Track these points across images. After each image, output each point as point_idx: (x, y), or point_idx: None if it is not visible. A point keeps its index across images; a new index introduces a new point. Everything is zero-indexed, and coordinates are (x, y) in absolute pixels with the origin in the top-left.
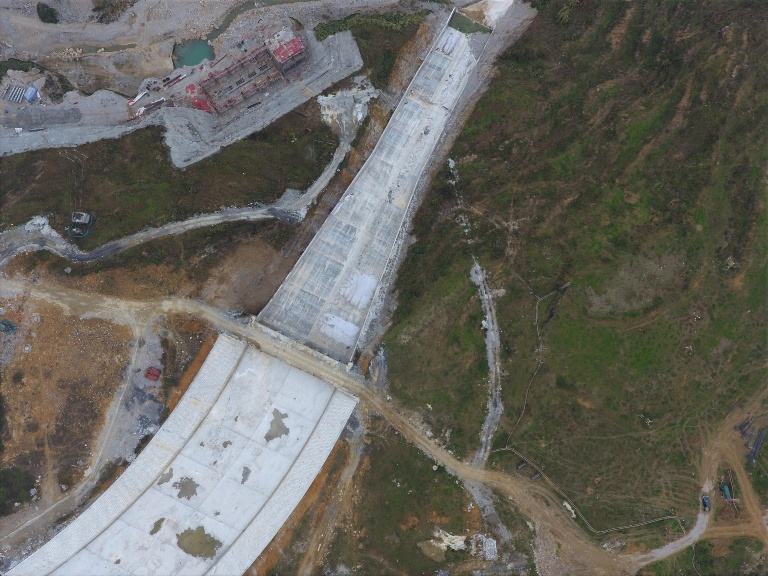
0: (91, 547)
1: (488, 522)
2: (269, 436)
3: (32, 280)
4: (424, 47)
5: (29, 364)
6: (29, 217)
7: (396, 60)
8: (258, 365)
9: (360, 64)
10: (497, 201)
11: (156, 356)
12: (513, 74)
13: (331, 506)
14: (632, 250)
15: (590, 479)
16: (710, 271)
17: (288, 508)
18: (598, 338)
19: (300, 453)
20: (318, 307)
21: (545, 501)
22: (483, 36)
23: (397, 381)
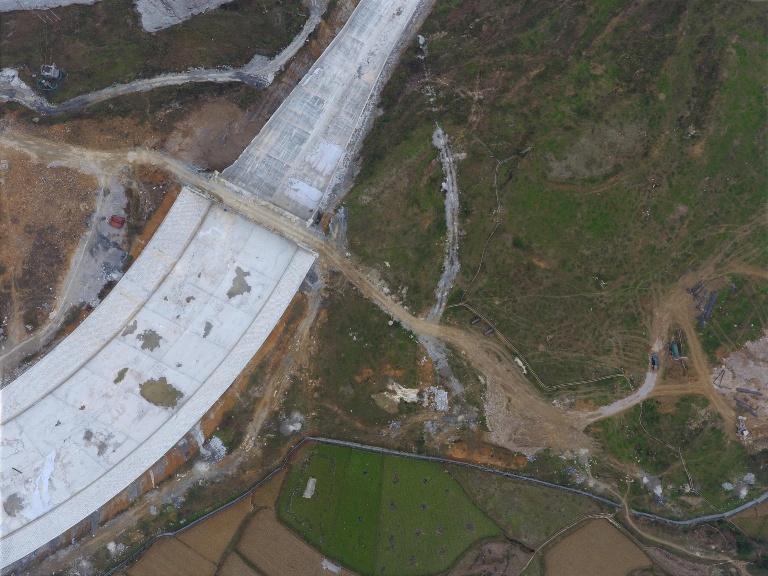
0: (57, 393)
1: (440, 375)
2: (231, 293)
3: (1, 128)
4: None
5: None
6: None
7: None
8: (222, 224)
9: None
10: (464, 72)
11: (120, 205)
12: None
13: (288, 355)
14: (594, 118)
15: (542, 336)
16: (671, 139)
17: (246, 357)
18: (556, 201)
19: (261, 310)
20: (283, 172)
21: (497, 356)
22: None
23: (356, 239)
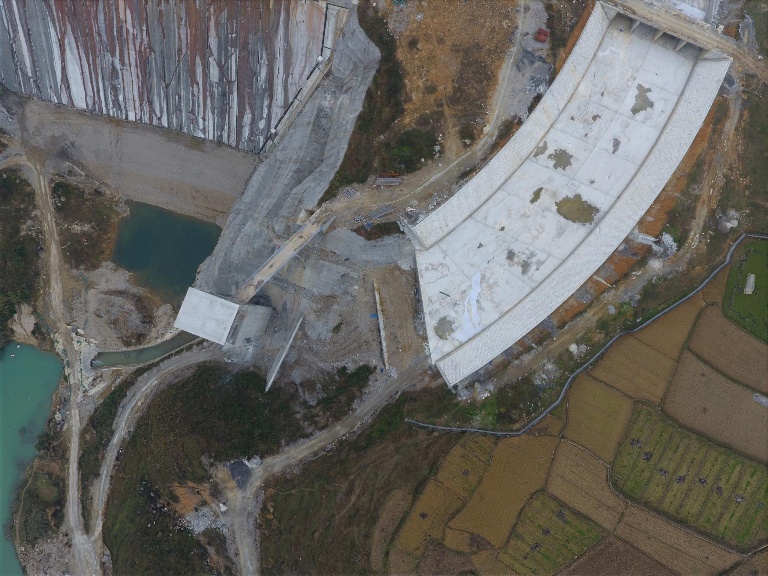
0: (476, 216)
1: None
2: (635, 109)
3: None
4: None
5: (422, 31)
6: None
7: None
8: (619, 44)
9: None
10: None
11: (541, 20)
12: None
13: (717, 155)
14: None
15: None
16: None
17: (673, 161)
18: None
19: (667, 123)
20: None
21: None
22: None
23: (765, 42)
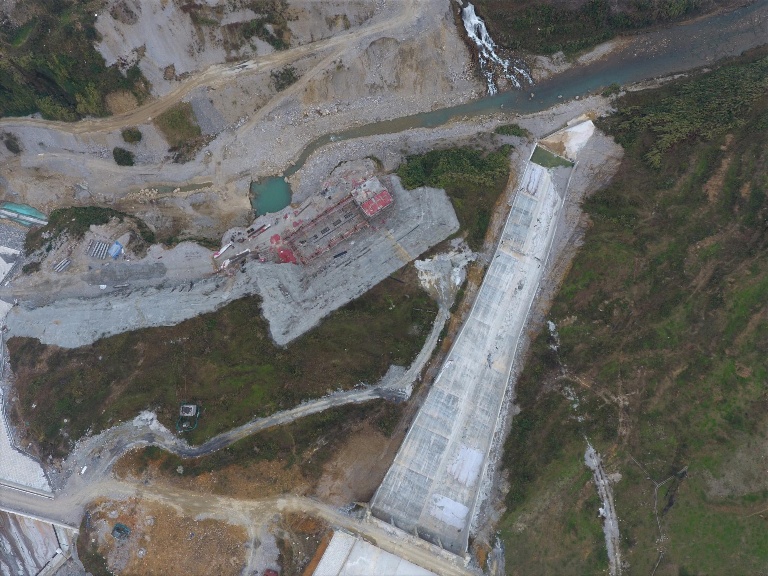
0: None
1: None
2: None
3: (144, 481)
4: (511, 192)
5: (144, 569)
6: (137, 412)
7: (491, 218)
8: (370, 553)
9: (456, 226)
10: (604, 373)
11: (272, 557)
12: (607, 225)
13: None
14: (748, 429)
15: None
16: None
17: None
18: (719, 526)
19: None
20: (426, 488)
21: None
22: (565, 170)
23: (515, 574)
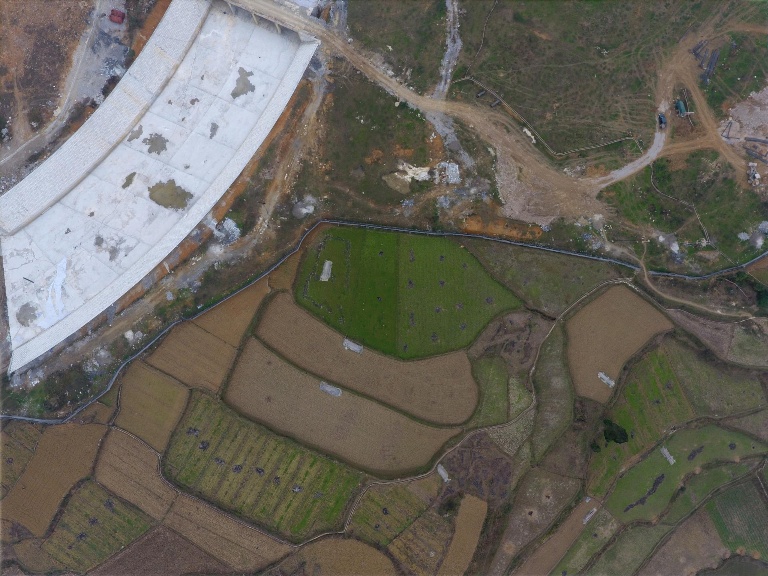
0: (65, 201)
1: (450, 149)
2: (235, 93)
3: None
4: None
5: None
6: None
7: None
8: (222, 26)
9: None
10: None
11: (120, 1)
12: None
13: (296, 139)
14: None
15: (548, 105)
16: None
17: (255, 146)
18: None
19: (266, 107)
20: None
21: (505, 128)
22: None
23: (357, 25)
